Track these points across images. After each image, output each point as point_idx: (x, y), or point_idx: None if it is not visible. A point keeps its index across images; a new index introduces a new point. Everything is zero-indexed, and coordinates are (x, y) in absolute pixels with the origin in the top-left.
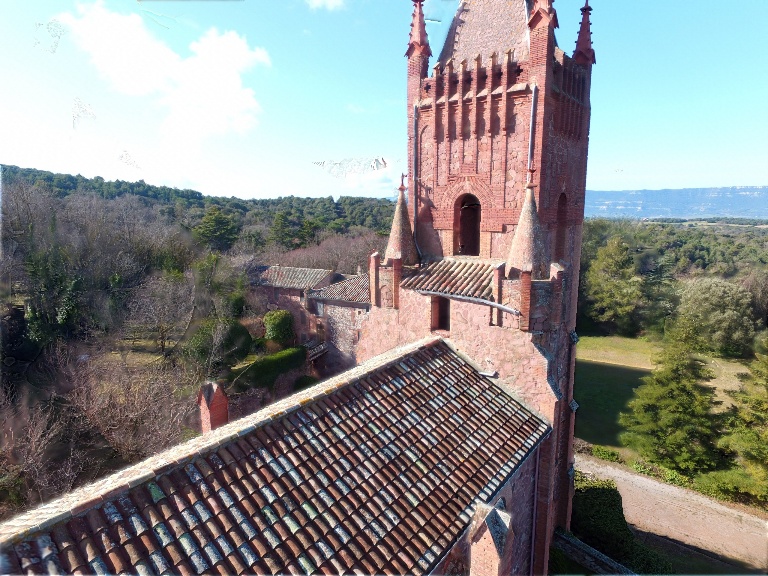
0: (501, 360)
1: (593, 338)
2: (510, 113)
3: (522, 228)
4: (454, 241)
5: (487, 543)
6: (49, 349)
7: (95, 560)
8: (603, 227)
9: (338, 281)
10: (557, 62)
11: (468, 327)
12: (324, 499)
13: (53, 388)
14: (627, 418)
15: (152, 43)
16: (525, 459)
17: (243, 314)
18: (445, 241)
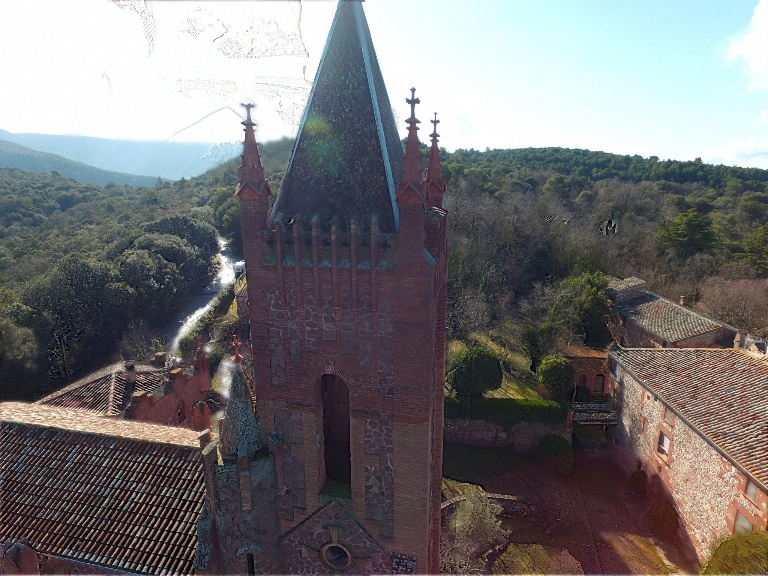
0: None
1: None
2: None
3: None
4: None
5: None
6: None
7: None
8: None
9: (728, 343)
10: None
11: None
12: None
13: None
14: None
15: None
16: (139, 574)
17: (511, 349)
18: None
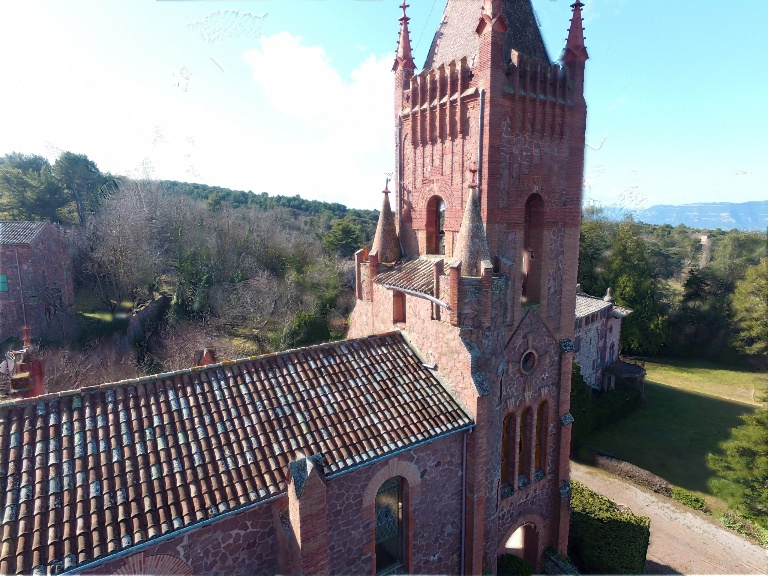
0: (439, 353)
1: (735, 373)
2: (464, 117)
3: (462, 226)
4: (428, 241)
5: (293, 485)
6: (162, 325)
7: (14, 434)
8: (758, 242)
9: None
10: (512, 64)
11: (417, 320)
12: (199, 433)
13: (163, 357)
14: (716, 461)
15: (219, 79)
16: (420, 443)
17: (327, 312)
18: (420, 241)
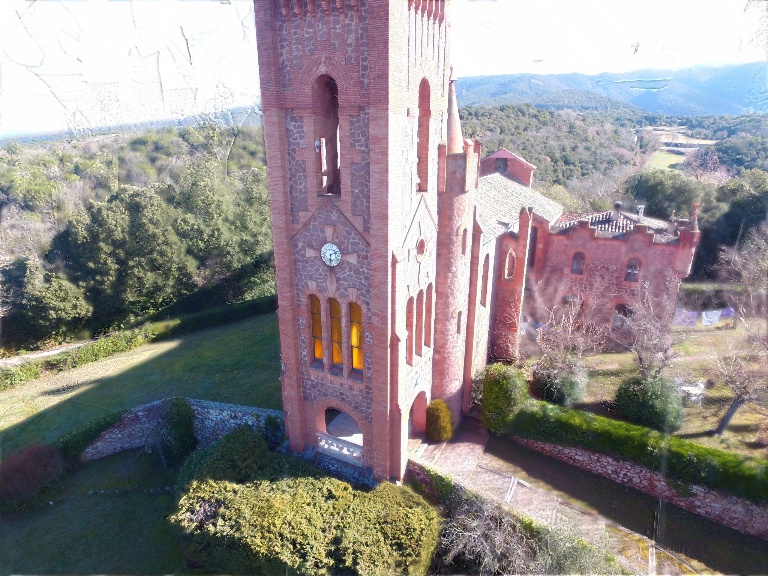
0: None
1: None
2: None
3: None
4: None
5: None
6: None
7: None
8: None
9: None
10: None
11: None
12: None
13: None
14: None
15: None
16: None
17: None
18: None
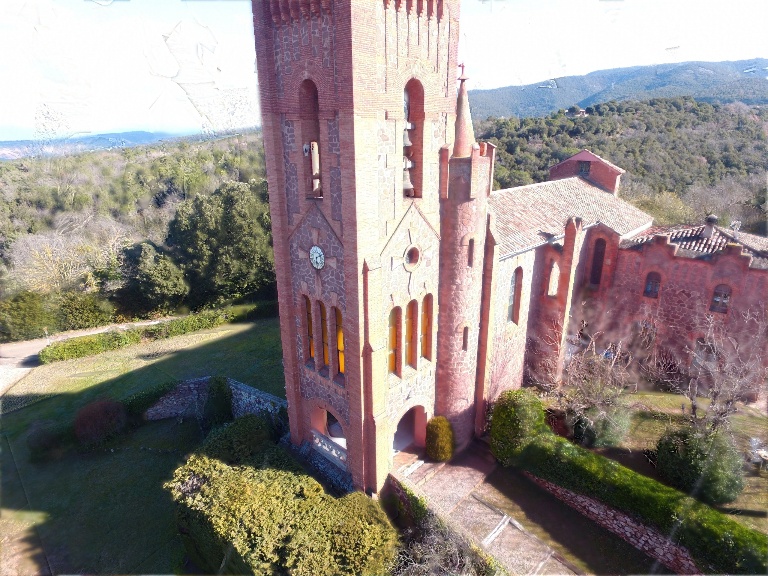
0: None
1: None
2: None
3: None
4: None
5: None
6: None
7: None
8: None
9: None
10: None
11: None
12: None
13: None
14: None
15: None
16: None
17: None
18: None
